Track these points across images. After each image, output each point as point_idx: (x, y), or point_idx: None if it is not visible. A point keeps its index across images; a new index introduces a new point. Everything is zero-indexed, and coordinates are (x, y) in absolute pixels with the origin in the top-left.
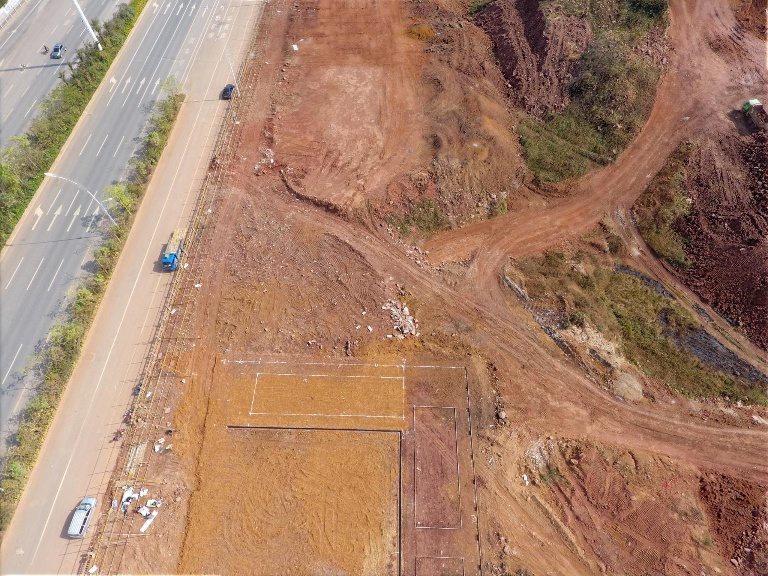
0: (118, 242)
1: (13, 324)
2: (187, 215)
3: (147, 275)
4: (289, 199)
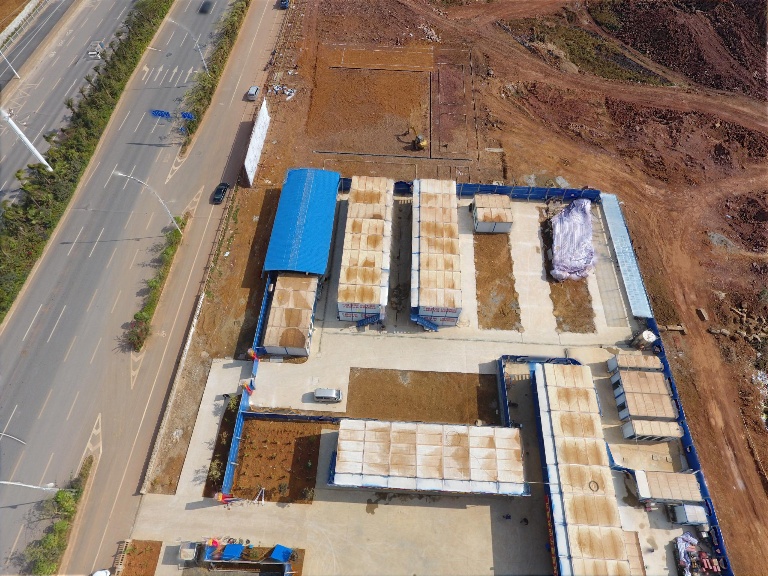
0: None
1: (193, 26)
2: None
3: (270, 10)
4: None
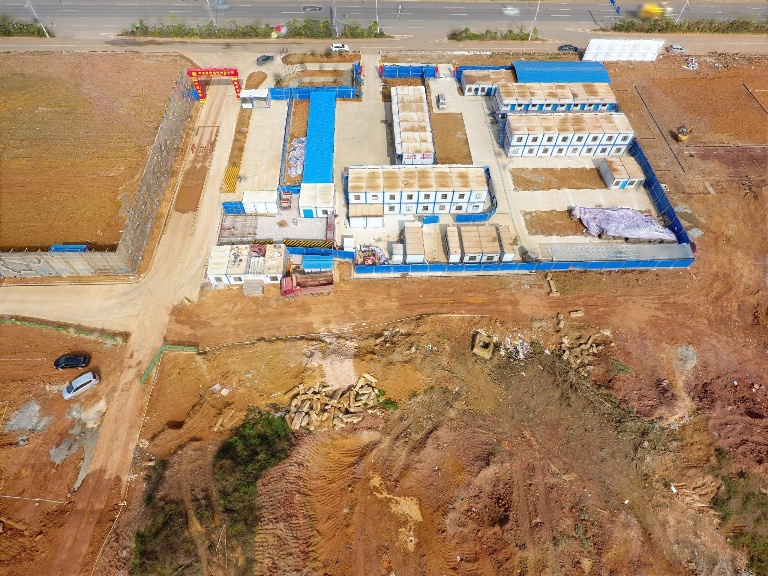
0: None
1: (733, 14)
2: None
3: None
4: None
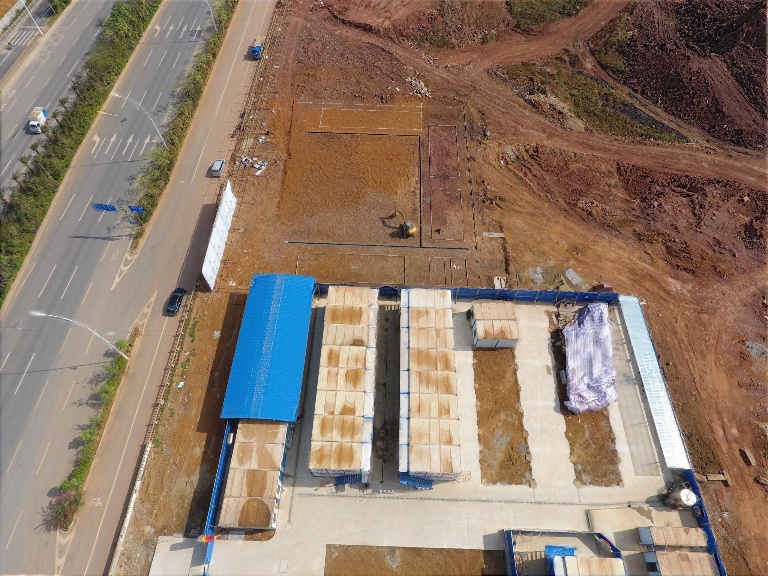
0: (218, 43)
1: (153, 83)
2: (263, 32)
3: (240, 61)
4: (336, 24)
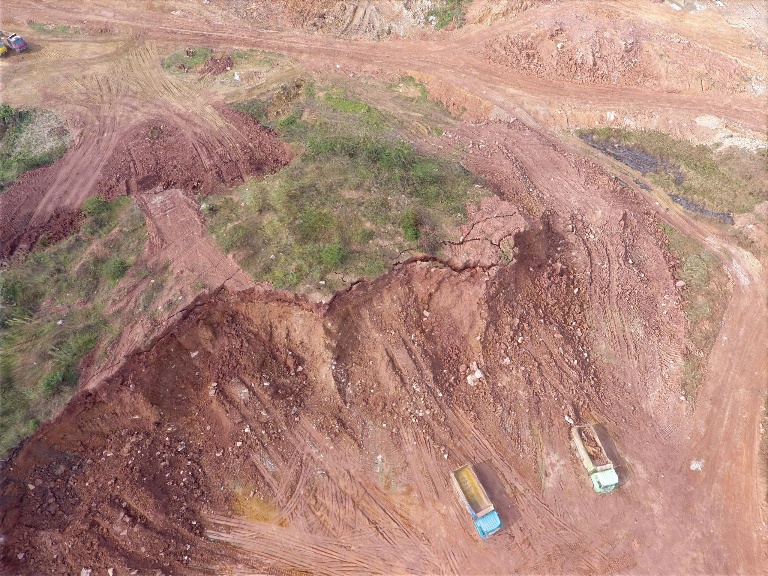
0: None
1: None
2: None
3: None
4: None
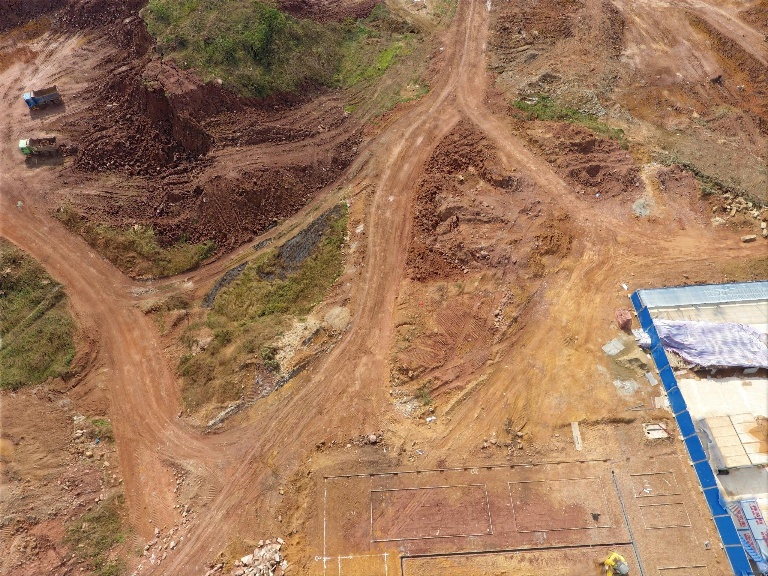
0: None
1: None
2: None
3: None
4: None
